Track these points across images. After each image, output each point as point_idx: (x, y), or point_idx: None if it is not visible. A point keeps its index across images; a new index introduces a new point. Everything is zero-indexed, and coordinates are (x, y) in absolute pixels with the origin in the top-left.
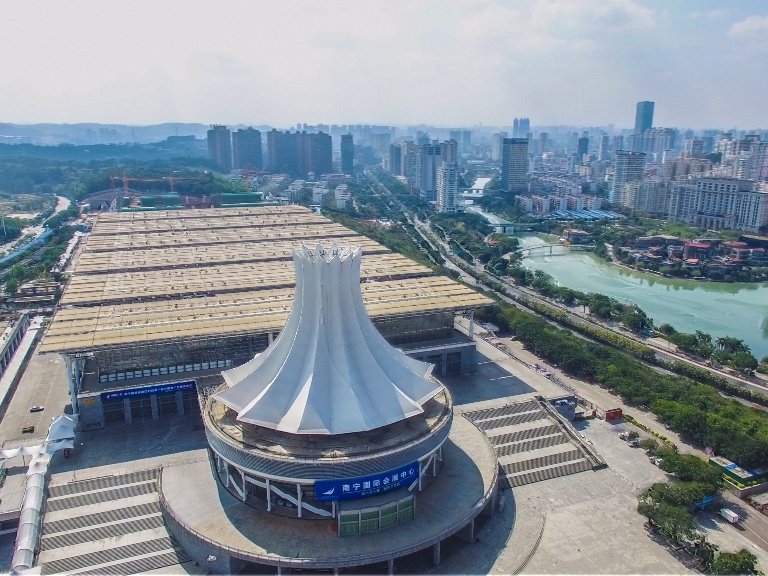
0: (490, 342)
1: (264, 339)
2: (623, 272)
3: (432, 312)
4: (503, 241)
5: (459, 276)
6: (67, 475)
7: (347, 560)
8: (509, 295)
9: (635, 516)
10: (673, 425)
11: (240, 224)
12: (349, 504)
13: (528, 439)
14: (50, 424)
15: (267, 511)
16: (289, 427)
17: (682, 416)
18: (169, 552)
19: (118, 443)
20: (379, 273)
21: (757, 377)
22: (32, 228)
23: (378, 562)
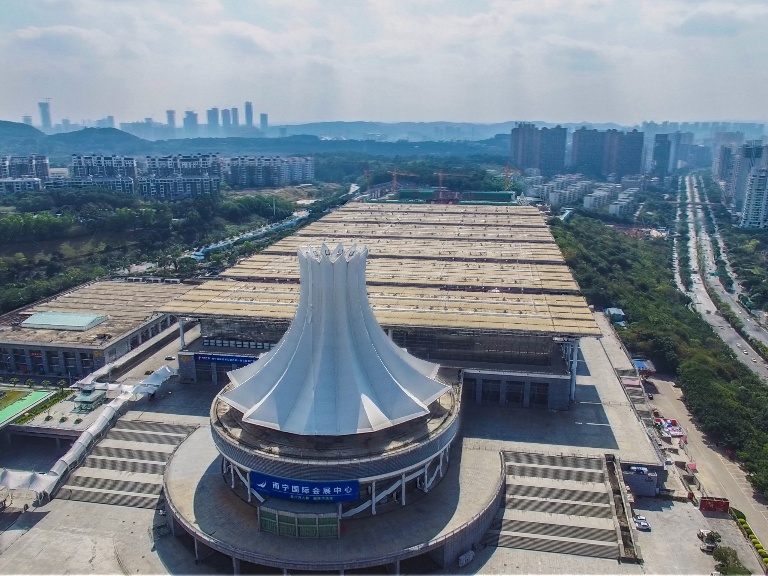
0: (621, 381)
1: None
2: None
3: (522, 333)
4: None
5: (691, 302)
6: (137, 414)
7: (243, 553)
8: (743, 334)
9: None
10: None
11: (450, 221)
12: (275, 502)
13: (560, 500)
14: (155, 371)
15: (231, 487)
16: None
17: None
18: (155, 497)
19: (192, 398)
20: (515, 284)
21: None
22: (305, 212)
23: (271, 566)
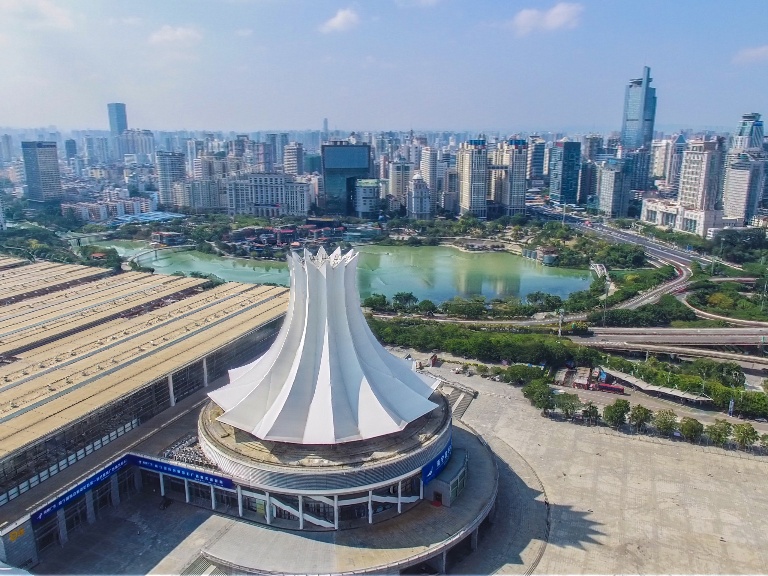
0: None
1: (165, 382)
2: (236, 264)
3: None
4: (103, 253)
5: None
6: None
7: (482, 516)
8: None
9: (532, 413)
10: (476, 353)
11: None
12: (444, 476)
13: None
14: None
15: (370, 524)
16: (382, 430)
17: (478, 345)
18: None
19: (96, 564)
20: (163, 292)
21: (436, 316)
22: None
23: None
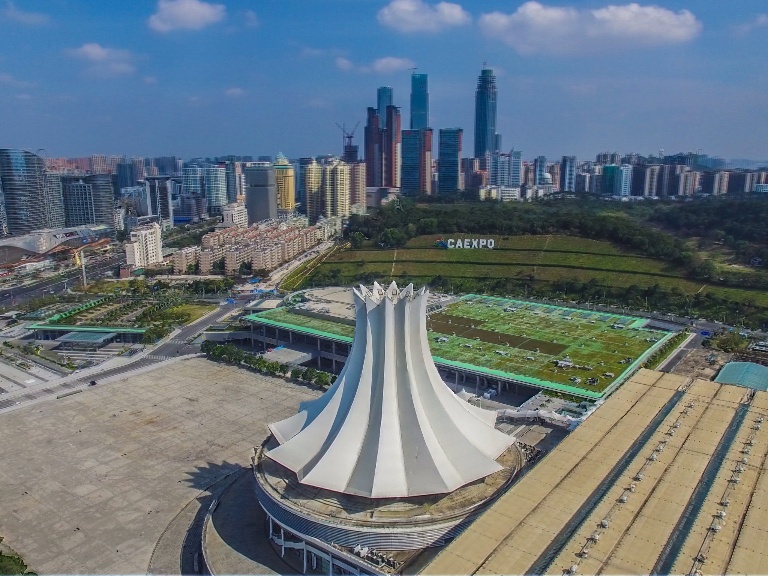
0: None
1: None
2: None
3: None
4: None
5: None
6: (543, 431)
7: None
8: None
9: None
10: None
11: None
12: None
13: None
14: None
15: None
16: None
17: None
18: None
19: None
20: None
21: None
22: None
23: None
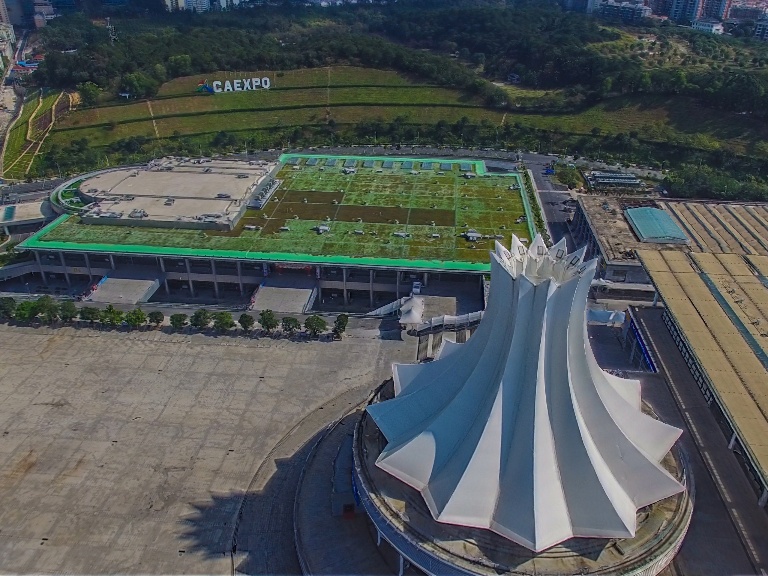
0: None
1: None
2: None
3: None
4: None
5: None
6: None
7: None
8: None
9: None
10: None
11: None
12: None
13: None
14: None
15: None
16: None
17: None
18: None
19: None
20: None
21: None
22: None
23: None
